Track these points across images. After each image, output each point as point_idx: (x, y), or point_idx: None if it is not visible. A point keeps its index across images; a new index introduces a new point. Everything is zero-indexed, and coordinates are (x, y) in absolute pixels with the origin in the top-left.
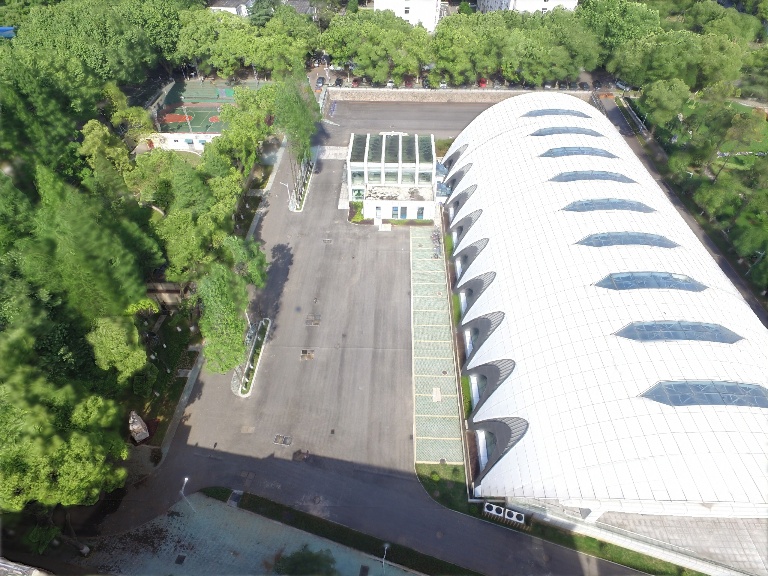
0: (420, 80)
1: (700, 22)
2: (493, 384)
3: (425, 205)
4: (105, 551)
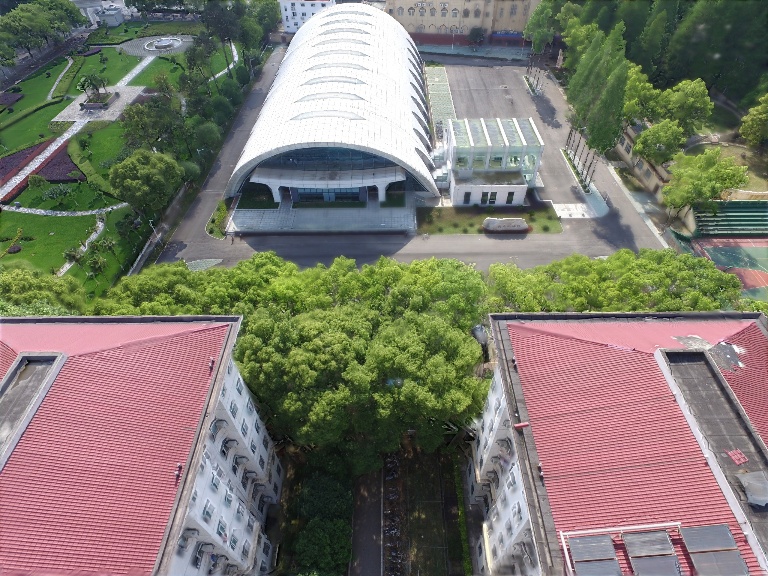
0: (494, 361)
1: None
2: None
3: None
4: None
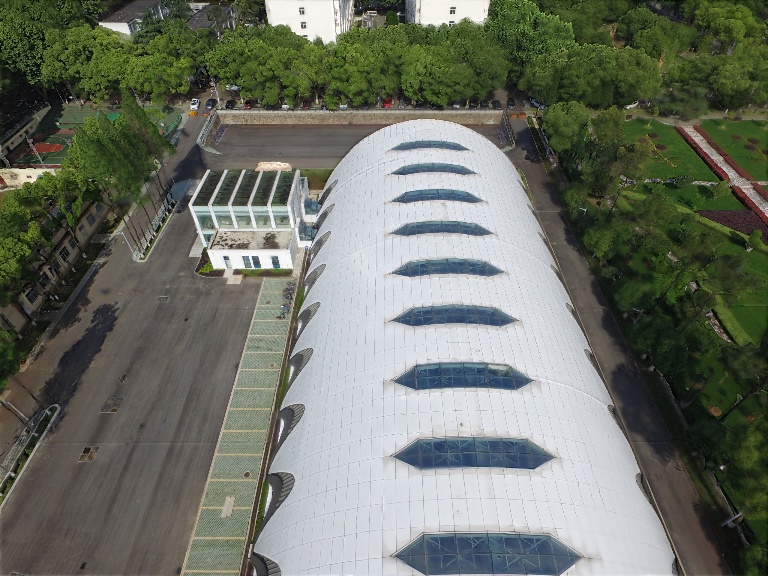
0: (321, 100)
1: (633, 31)
2: (273, 506)
3: (278, 254)
4: None
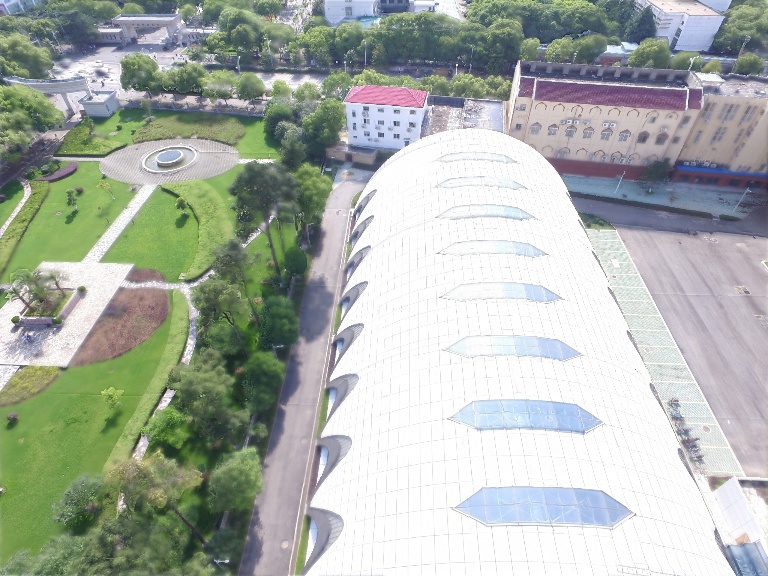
0: None
1: None
2: None
3: None
4: (764, 201)
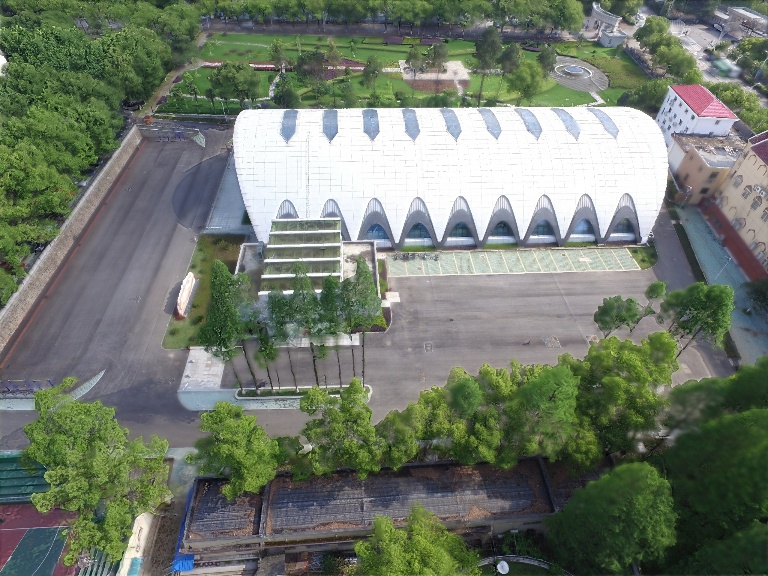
0: None
1: None
2: (592, 213)
3: None
4: None
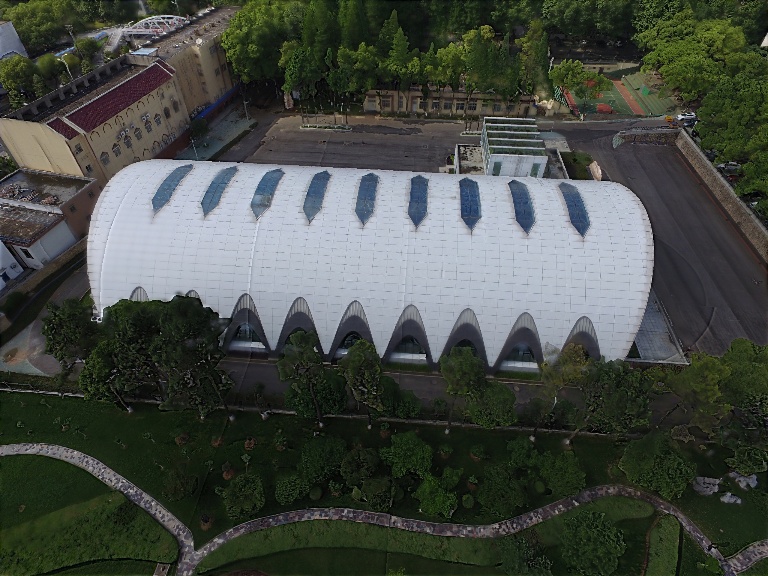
0: None
1: None
2: None
3: None
4: None
